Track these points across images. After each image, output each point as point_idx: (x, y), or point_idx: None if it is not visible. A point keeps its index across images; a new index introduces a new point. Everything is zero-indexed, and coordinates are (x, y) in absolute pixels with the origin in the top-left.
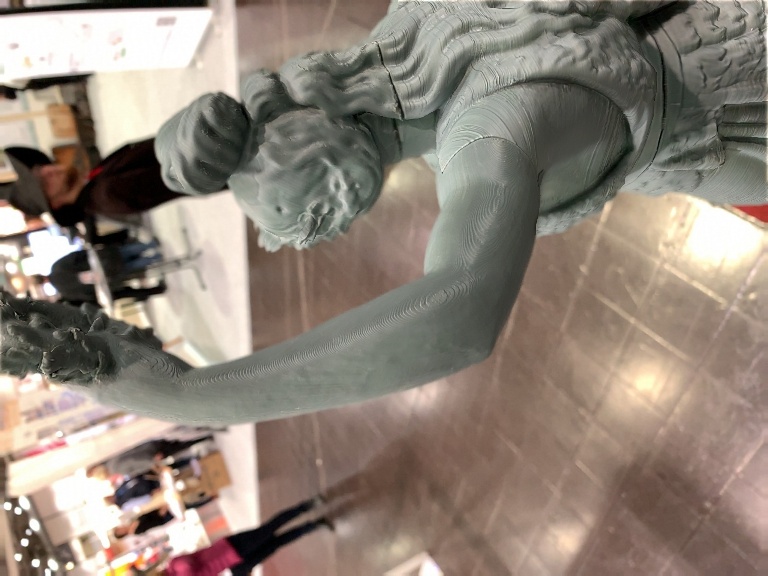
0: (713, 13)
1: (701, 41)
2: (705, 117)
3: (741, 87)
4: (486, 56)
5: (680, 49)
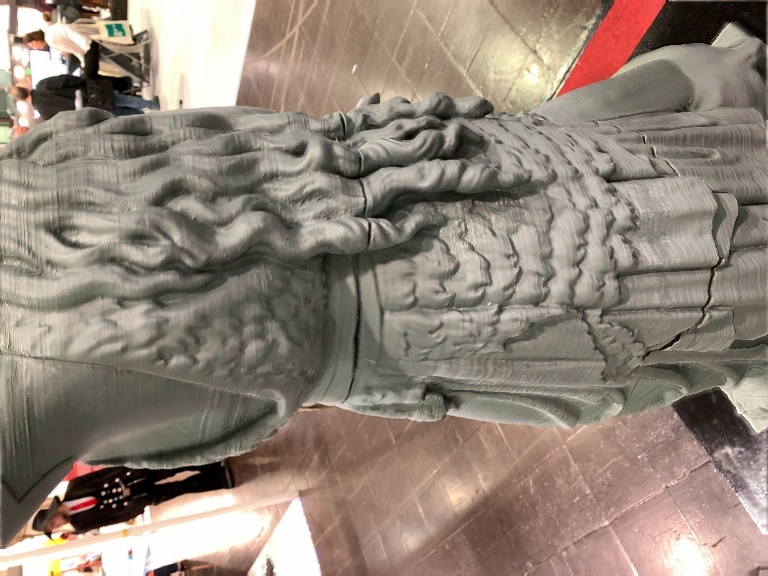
0: (446, 270)
1: (417, 301)
2: (410, 380)
3: (456, 365)
4: (10, 305)
5: (386, 304)
